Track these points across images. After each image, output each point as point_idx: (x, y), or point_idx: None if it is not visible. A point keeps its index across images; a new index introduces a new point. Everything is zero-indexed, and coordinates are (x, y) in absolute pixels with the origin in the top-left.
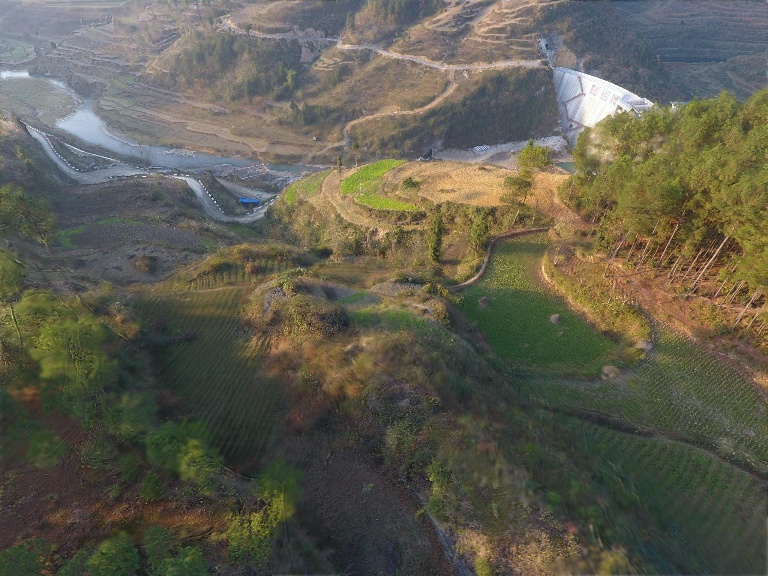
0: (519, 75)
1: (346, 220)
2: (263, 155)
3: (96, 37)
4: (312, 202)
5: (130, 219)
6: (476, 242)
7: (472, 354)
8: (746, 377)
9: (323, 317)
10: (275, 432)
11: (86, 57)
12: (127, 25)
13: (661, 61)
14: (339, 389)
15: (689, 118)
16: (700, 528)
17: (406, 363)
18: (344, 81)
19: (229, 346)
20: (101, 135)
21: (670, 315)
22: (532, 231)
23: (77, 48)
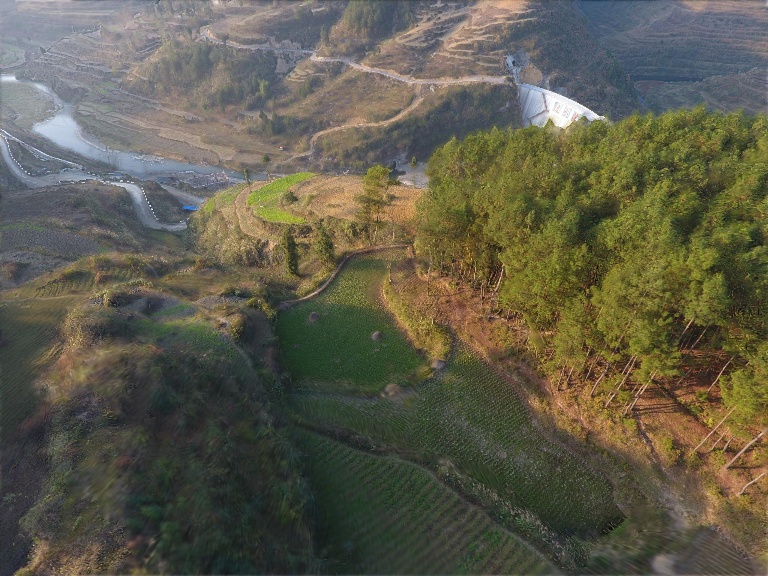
0: (483, 91)
1: (243, 231)
2: (229, 163)
3: (83, 44)
4: (223, 212)
5: (35, 225)
6: (324, 258)
7: (248, 369)
8: (523, 399)
9: (85, 329)
10: (2, 440)
11: (71, 63)
12: (113, 33)
13: (631, 80)
14: (51, 400)
15: (512, 143)
16: (382, 547)
17: (115, 377)
18: (315, 92)
19: (30, 354)
20: (75, 140)
21: (472, 336)
22: (390, 248)
23: (64, 54)
